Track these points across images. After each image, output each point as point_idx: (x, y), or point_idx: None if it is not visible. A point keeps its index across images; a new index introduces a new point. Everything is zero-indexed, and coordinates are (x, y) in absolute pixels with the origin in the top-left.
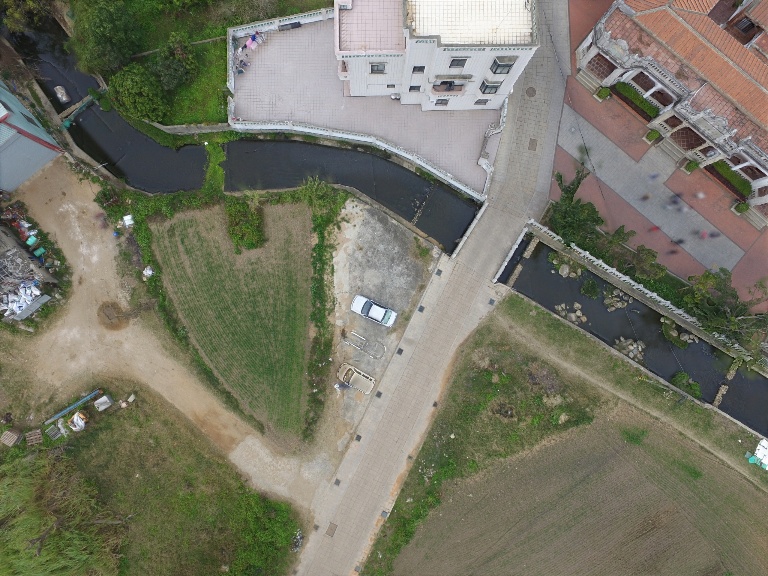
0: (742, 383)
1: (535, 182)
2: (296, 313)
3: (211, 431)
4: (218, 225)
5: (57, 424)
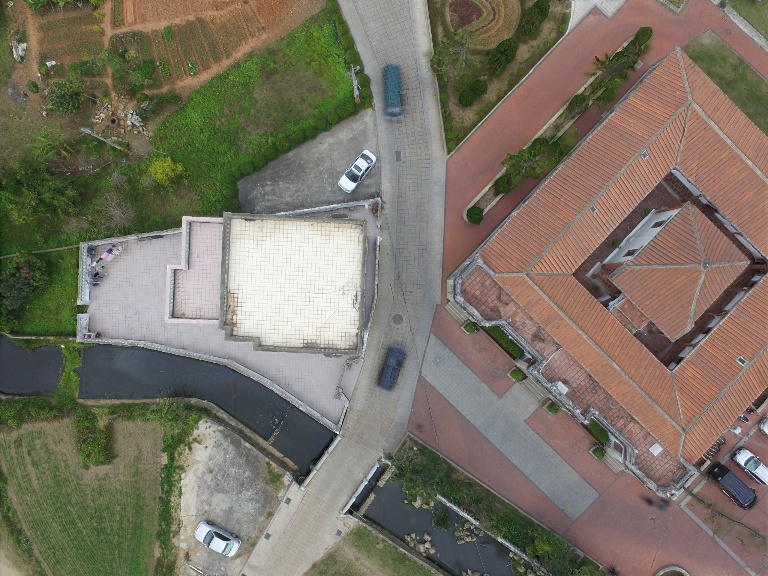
0: None
1: (394, 412)
2: (142, 531)
3: None
4: (67, 438)
5: None
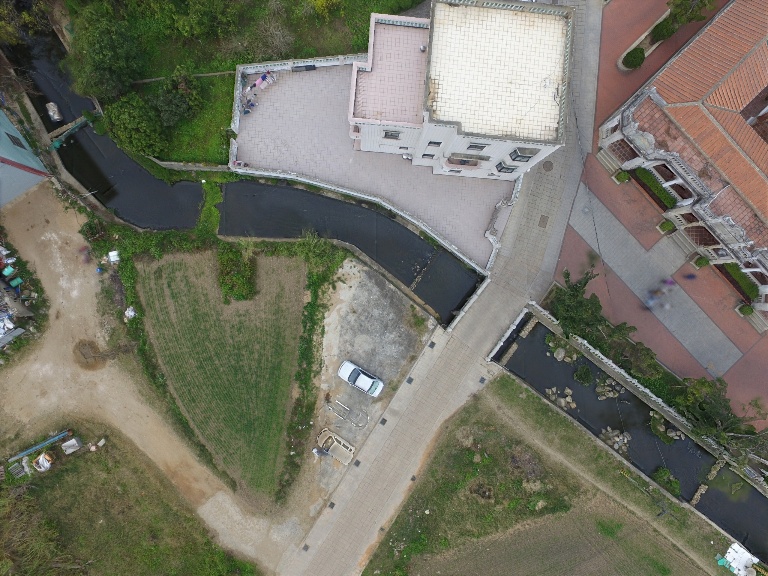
0: (722, 484)
1: (541, 261)
2: (281, 371)
3: (181, 483)
4: (208, 271)
5: (21, 462)
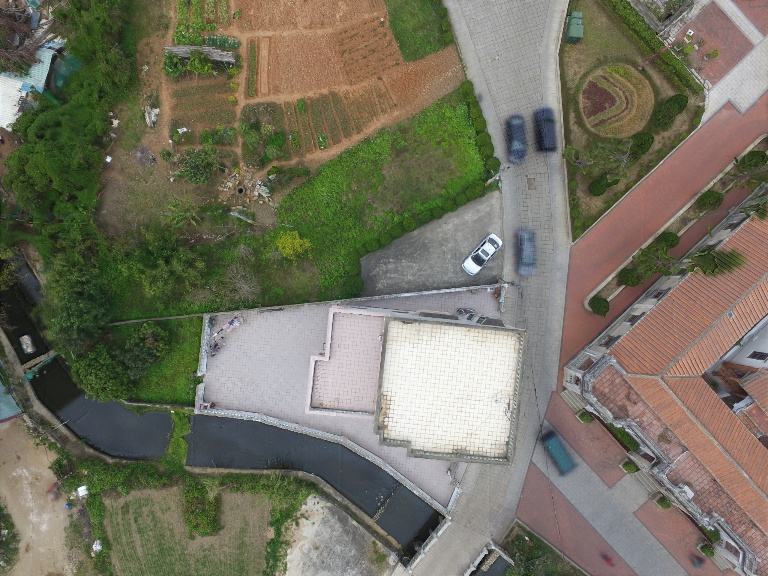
0: None
1: (503, 497)
2: None
3: None
4: (174, 506)
5: None
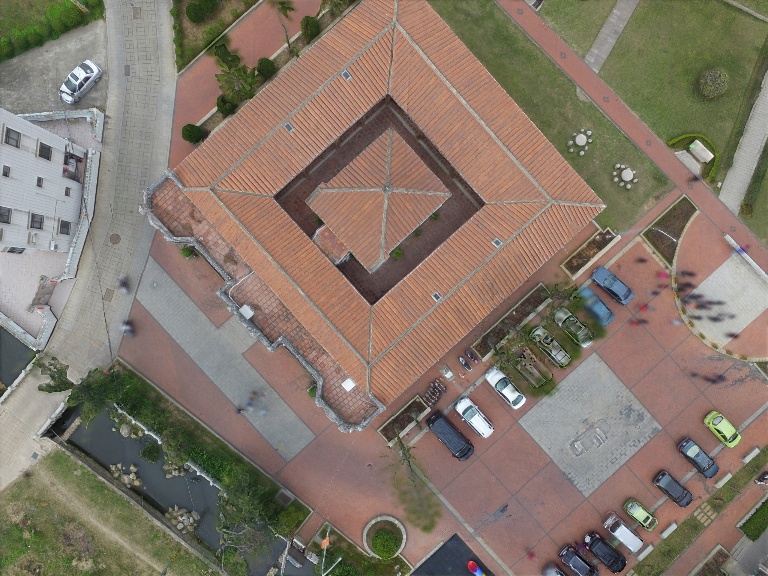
0: (294, 567)
1: (105, 335)
2: None
3: None
4: None
5: None
